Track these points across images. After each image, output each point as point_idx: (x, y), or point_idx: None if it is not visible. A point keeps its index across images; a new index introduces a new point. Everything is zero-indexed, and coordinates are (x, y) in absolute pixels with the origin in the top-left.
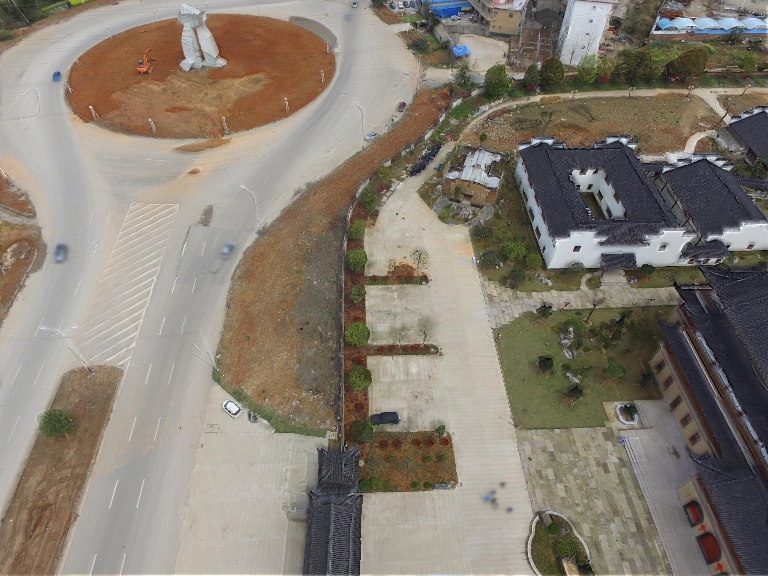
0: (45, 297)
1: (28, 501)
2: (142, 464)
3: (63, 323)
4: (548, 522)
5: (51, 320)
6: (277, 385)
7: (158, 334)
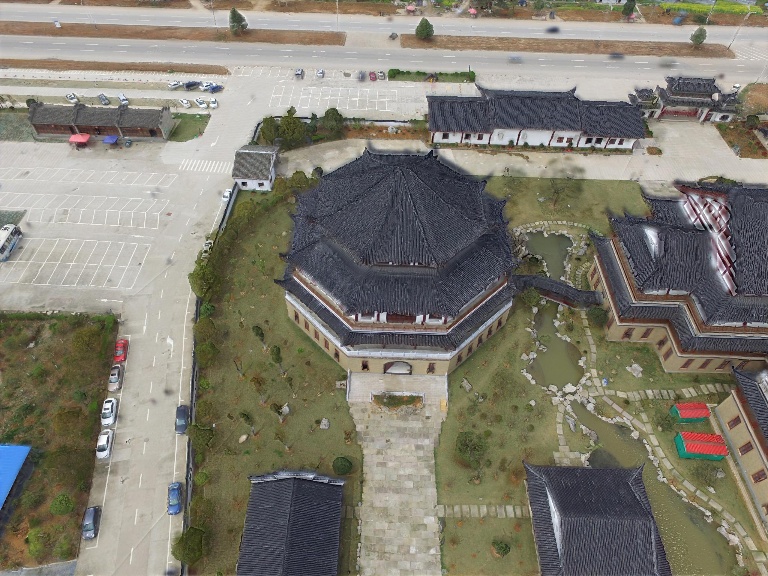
0: (761, 33)
1: (660, 45)
2: (691, 68)
3: (749, 40)
4: (738, 183)
5: (748, 37)
6: (760, 102)
7: (764, 65)
